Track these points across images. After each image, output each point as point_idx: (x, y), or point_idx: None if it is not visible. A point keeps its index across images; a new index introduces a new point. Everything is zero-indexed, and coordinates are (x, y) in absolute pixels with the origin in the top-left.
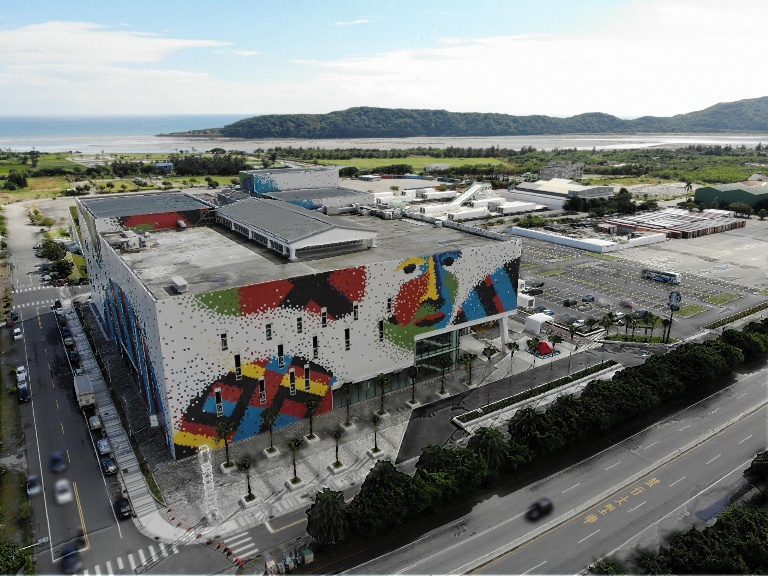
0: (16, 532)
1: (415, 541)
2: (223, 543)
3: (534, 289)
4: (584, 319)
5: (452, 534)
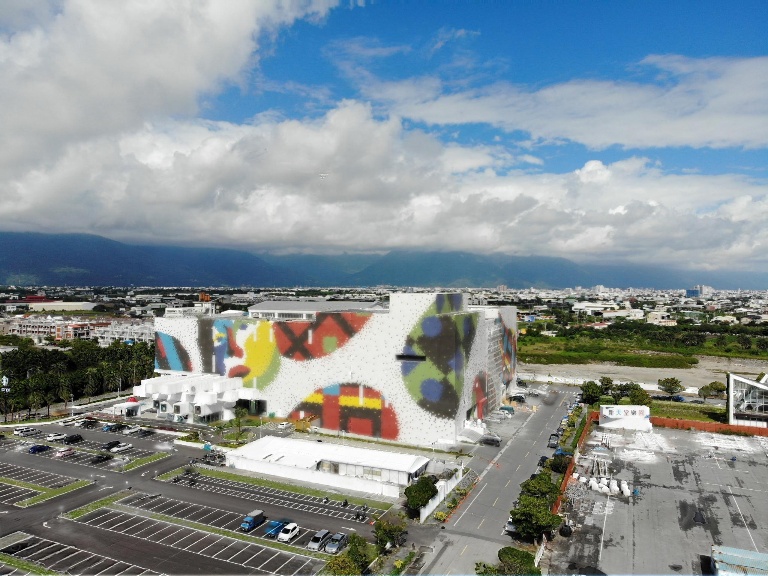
0: None
1: None
2: None
3: (116, 441)
4: (71, 430)
5: None
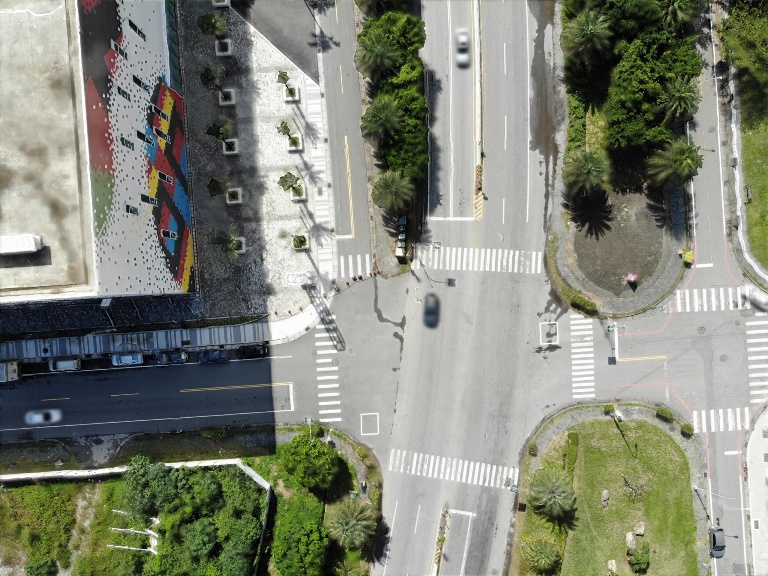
0: (237, 440)
1: (429, 129)
2: (344, 279)
3: None
4: None
5: (438, 95)
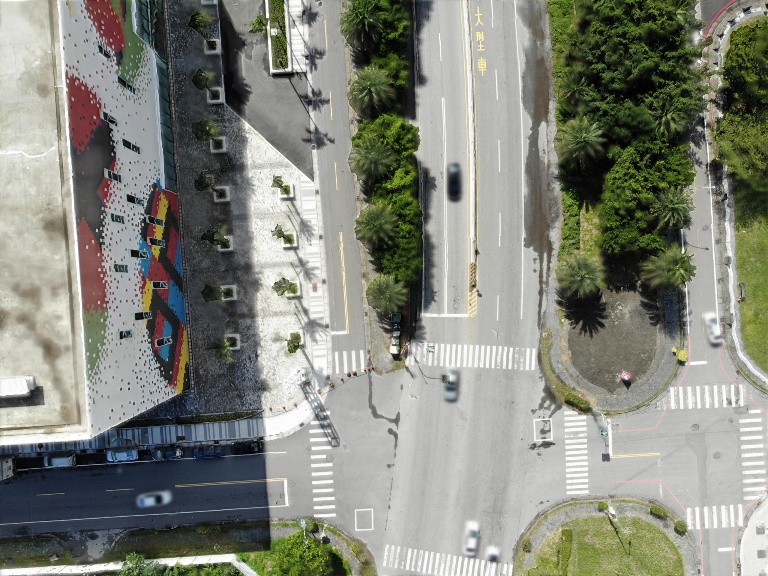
0: (232, 535)
1: (423, 226)
2: (339, 375)
3: None
4: None
5: (433, 192)
